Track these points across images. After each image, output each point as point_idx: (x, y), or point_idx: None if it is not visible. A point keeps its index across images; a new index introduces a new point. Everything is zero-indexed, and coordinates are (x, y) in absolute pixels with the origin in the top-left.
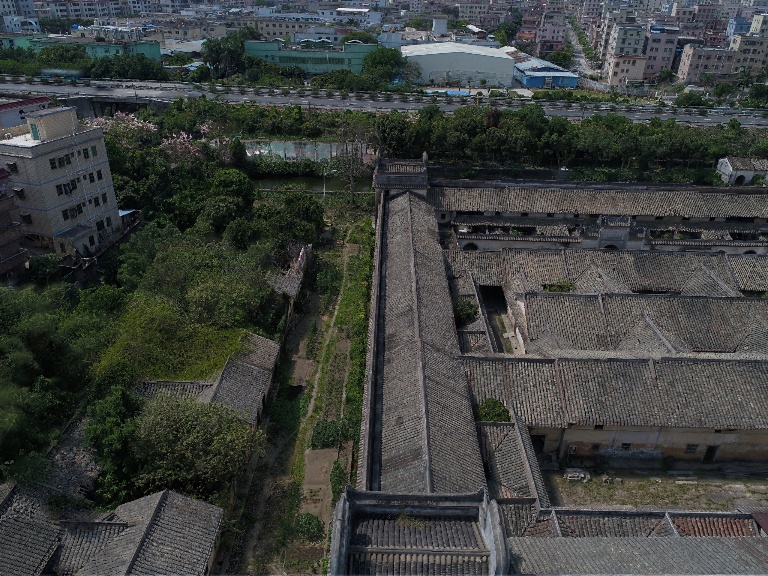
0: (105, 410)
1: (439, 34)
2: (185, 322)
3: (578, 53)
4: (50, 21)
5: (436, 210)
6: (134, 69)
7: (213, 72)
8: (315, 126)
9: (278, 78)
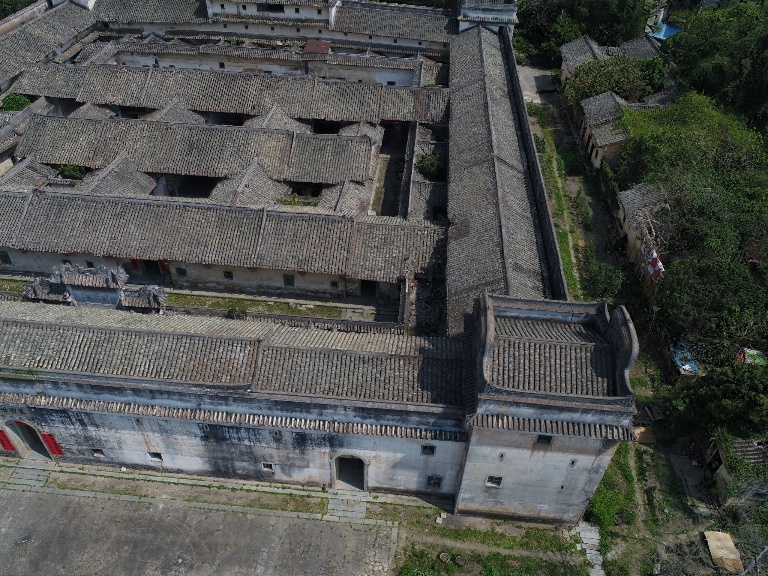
0: None
1: None
2: None
3: None
4: None
5: None
6: None
7: None
8: None
9: None
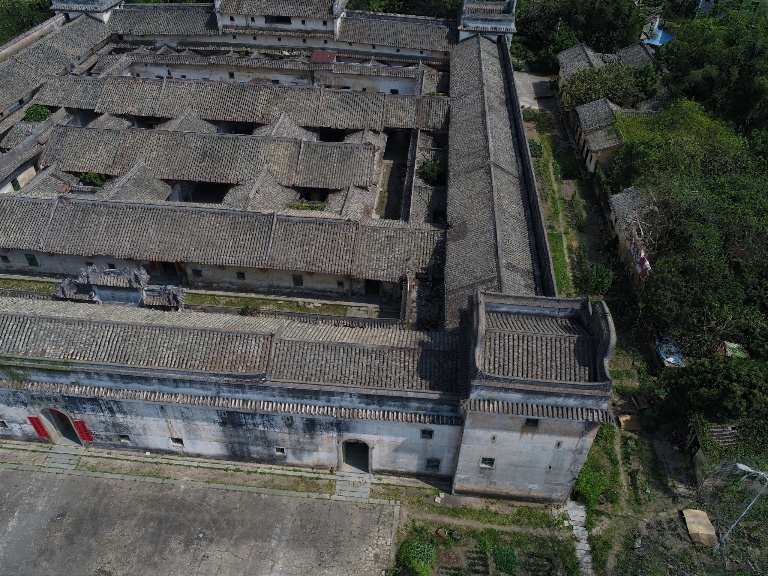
0: (647, 65)
1: None
2: None
3: None
4: None
5: None
6: None
7: None
8: None
9: None
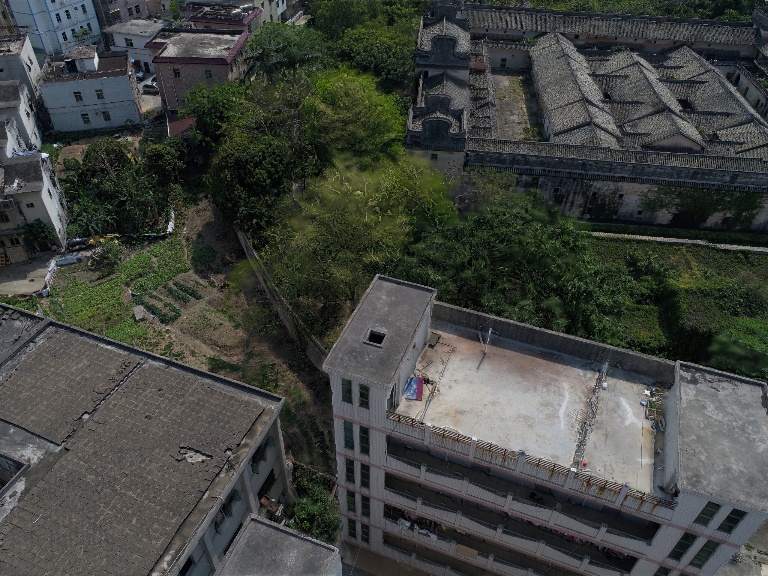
0: None
1: None
2: (568, 3)
3: None
4: None
5: None
6: None
7: None
8: None
9: None
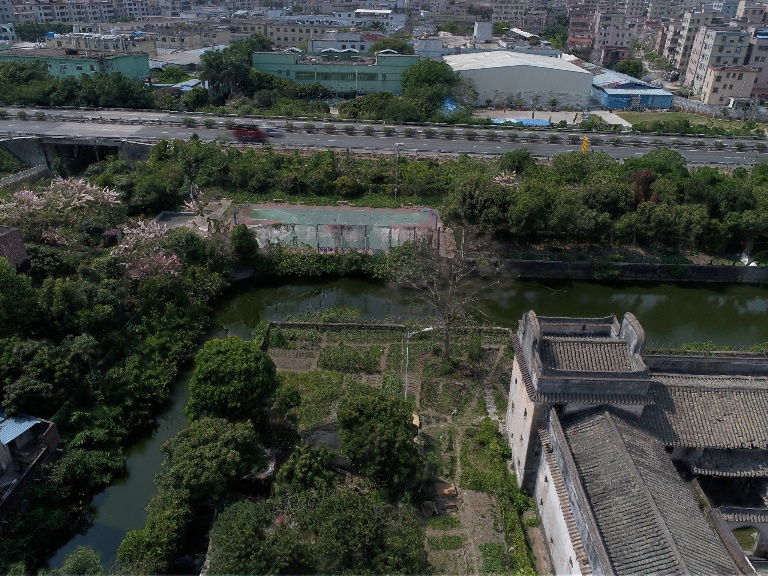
0: None
1: (483, 40)
2: None
3: (639, 60)
4: (27, 27)
5: (663, 445)
6: (107, 93)
7: (213, 92)
8: (355, 182)
9: (297, 103)
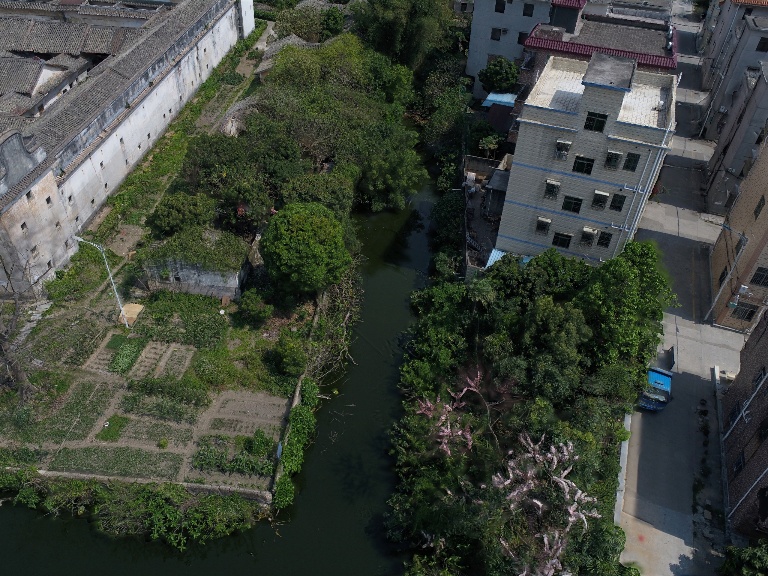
0: None
1: None
2: None
3: None
4: None
5: None
6: None
7: None
8: None
9: None
